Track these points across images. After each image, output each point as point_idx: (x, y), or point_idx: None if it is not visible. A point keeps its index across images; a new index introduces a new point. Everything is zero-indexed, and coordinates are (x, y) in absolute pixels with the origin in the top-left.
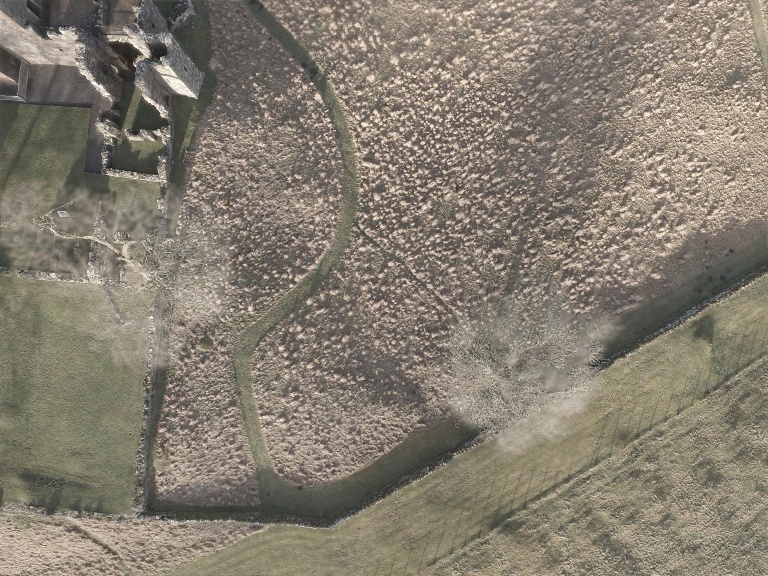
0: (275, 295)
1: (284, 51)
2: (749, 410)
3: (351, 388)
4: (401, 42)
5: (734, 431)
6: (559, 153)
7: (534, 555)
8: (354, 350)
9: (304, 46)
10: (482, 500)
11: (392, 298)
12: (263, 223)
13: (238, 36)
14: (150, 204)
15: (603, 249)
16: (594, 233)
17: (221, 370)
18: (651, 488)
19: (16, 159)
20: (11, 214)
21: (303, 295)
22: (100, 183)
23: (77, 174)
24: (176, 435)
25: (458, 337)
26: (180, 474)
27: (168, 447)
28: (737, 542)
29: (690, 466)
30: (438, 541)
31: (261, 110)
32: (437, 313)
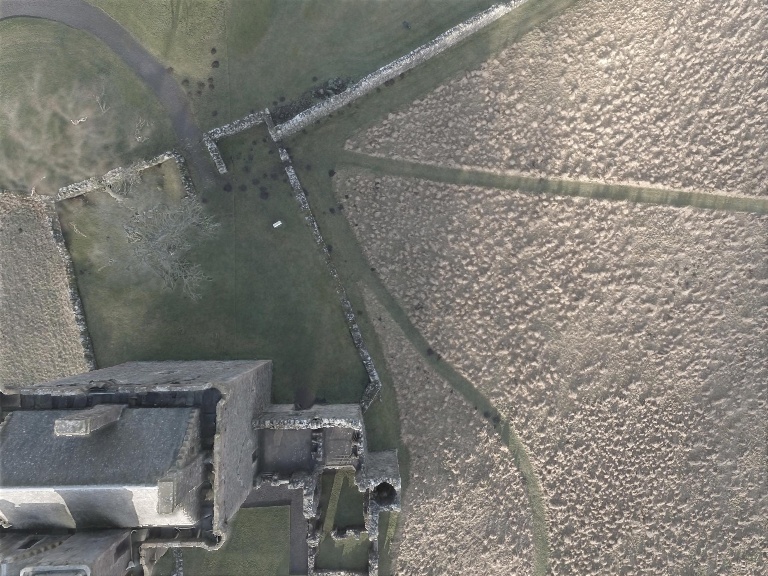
0: None
1: (466, 403)
2: None
3: None
4: (576, 373)
5: None
6: (740, 469)
7: None
8: None
9: (485, 394)
10: None
11: None
12: None
13: (422, 397)
14: None
15: None
16: None
17: None
18: None
19: (219, 568)
20: None
21: None
22: None
23: None
24: None
25: None
26: None
27: None
28: None
29: None
30: None
31: (454, 477)
32: None
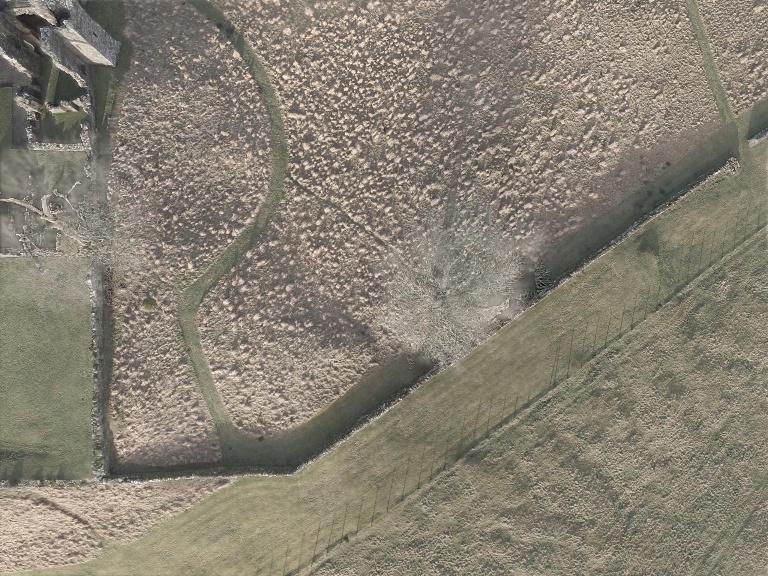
0: (214, 251)
1: (198, 14)
2: (705, 319)
3: (300, 335)
4: None
5: (691, 341)
6: (483, 85)
7: (502, 482)
8: (299, 298)
9: (218, 7)
10: (444, 433)
11: (332, 243)
12: (195, 182)
13: (151, 4)
14: (79, 173)
15: (538, 174)
16: (527, 159)
17: (168, 329)
18: (613, 405)
19: None
20: None
21: (242, 249)
22: (28, 158)
23: (5, 152)
24: (129, 397)
25: (401, 275)
26: (138, 435)
27: (122, 409)
28: (708, 452)
29: (650, 380)
30: (404, 477)
31: (180, 72)
32: (378, 253)
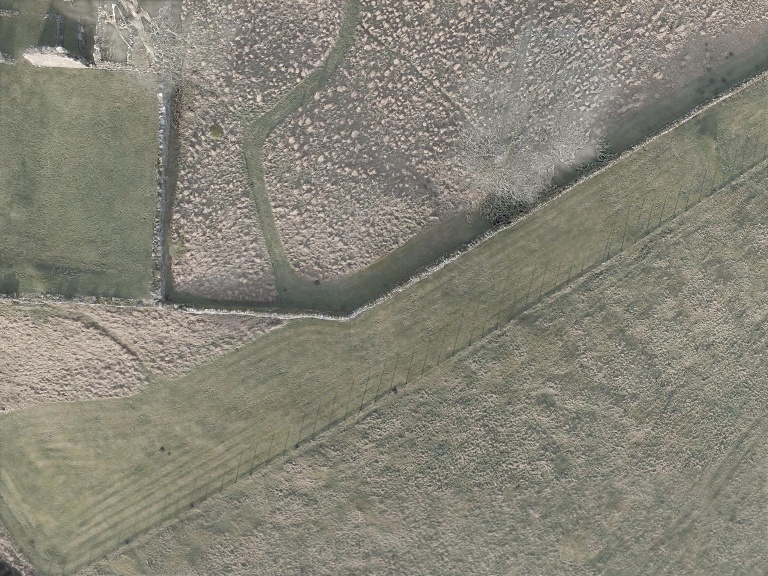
0: (283, 88)
1: None
2: (755, 211)
3: (363, 181)
4: None
5: (741, 229)
6: None
7: (551, 348)
8: (364, 146)
9: None
10: (498, 294)
11: (399, 95)
12: (267, 17)
13: None
14: None
15: (605, 49)
16: (596, 33)
17: (232, 160)
18: (663, 284)
19: None
20: (13, 3)
21: (311, 91)
22: None
23: None
24: (190, 222)
25: (466, 132)
26: (196, 264)
27: (183, 234)
28: (749, 340)
29: (700, 262)
30: (456, 333)
31: None
32: (445, 110)
